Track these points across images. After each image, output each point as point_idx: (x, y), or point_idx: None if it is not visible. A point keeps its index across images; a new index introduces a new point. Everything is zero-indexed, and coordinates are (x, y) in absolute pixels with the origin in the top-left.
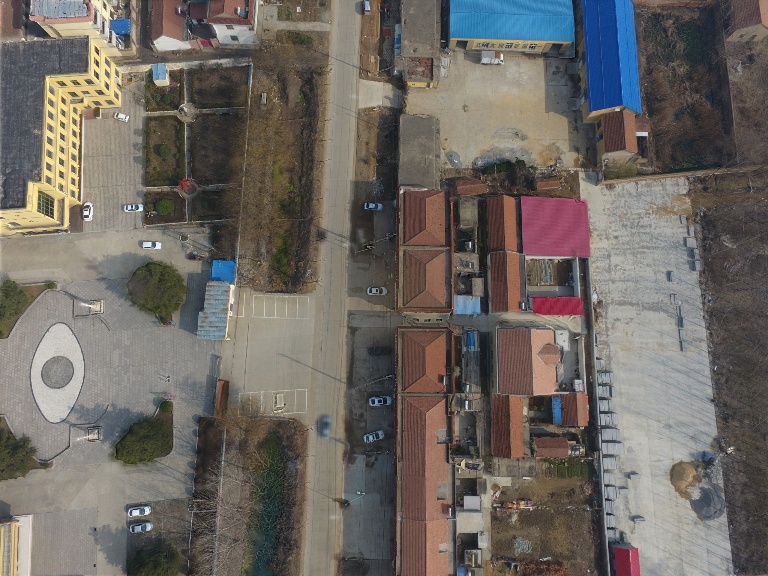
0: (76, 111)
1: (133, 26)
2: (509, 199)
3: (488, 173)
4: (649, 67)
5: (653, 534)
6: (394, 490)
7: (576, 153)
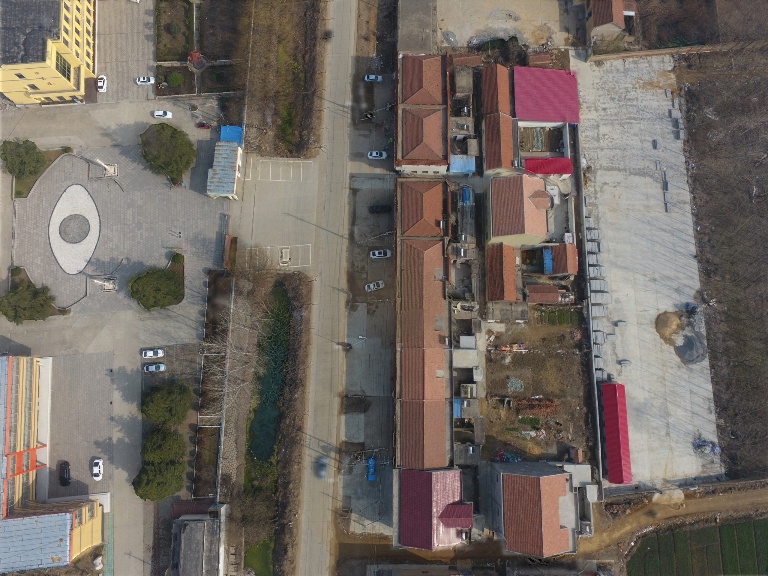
0: None
1: None
2: (502, 68)
3: (483, 50)
4: None
5: (639, 376)
6: None
7: (566, 33)
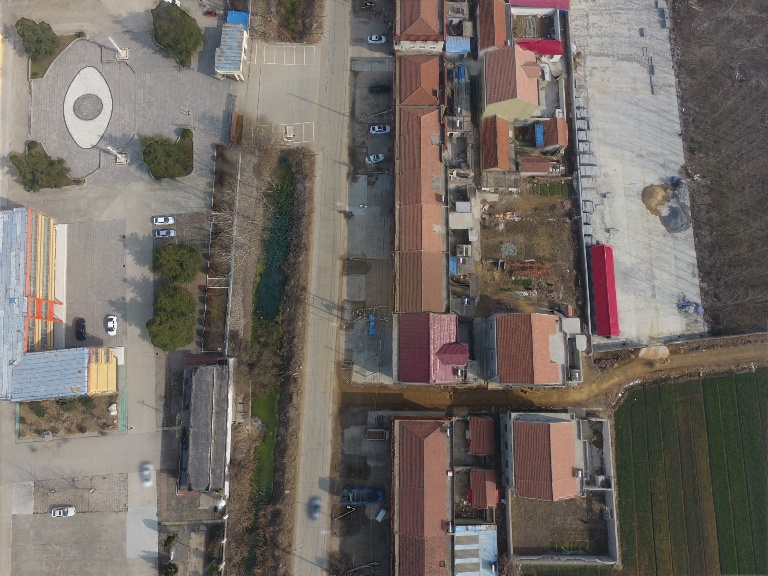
0: None
1: None
2: None
3: None
4: None
5: (626, 243)
6: None
7: None
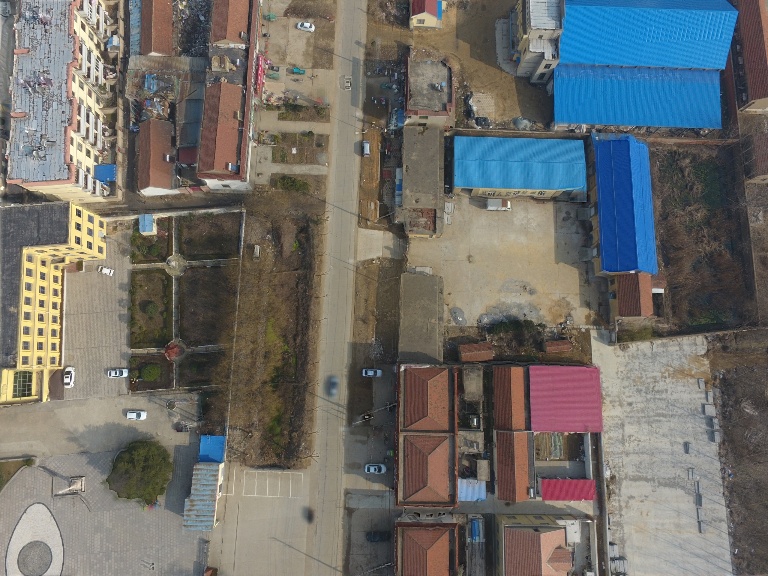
0: (57, 267)
1: (119, 170)
2: (517, 370)
3: (494, 333)
4: (665, 211)
5: None
6: None
7: (587, 309)
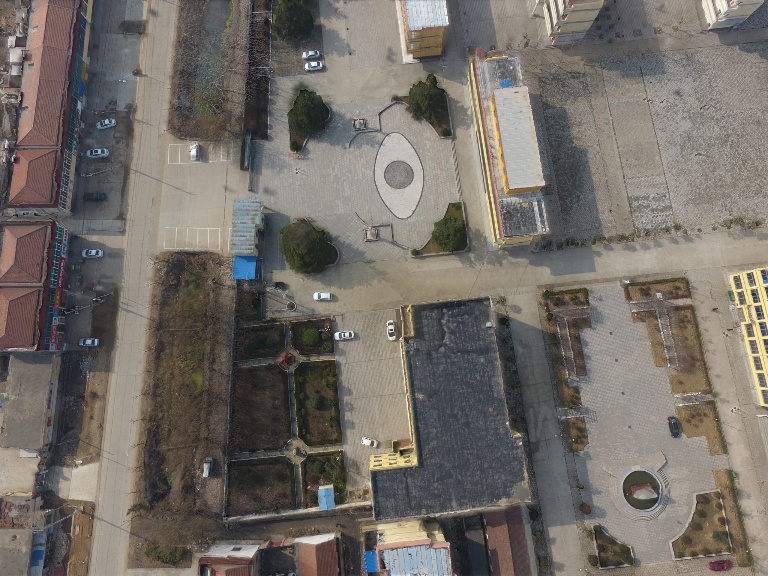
0: None
1: None
2: None
3: None
4: None
5: None
6: (81, 76)
7: None
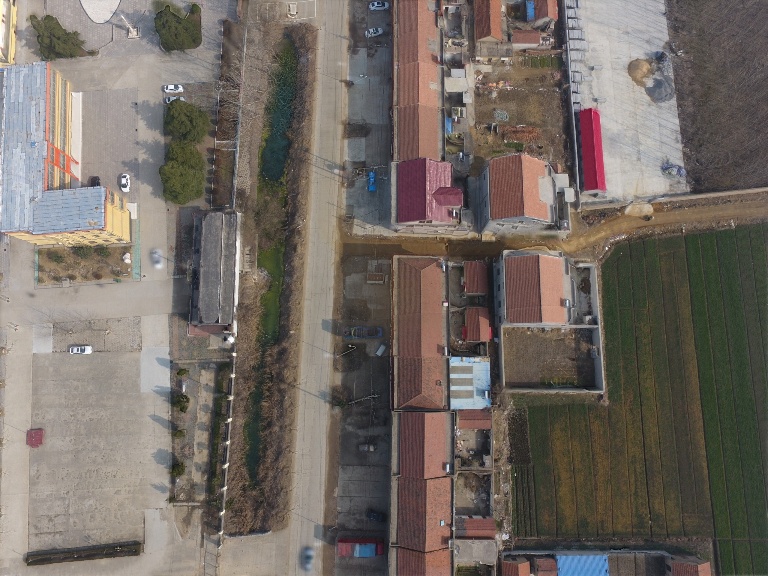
0: None
1: None
2: None
3: None
4: None
5: (613, 112)
6: None
7: None
